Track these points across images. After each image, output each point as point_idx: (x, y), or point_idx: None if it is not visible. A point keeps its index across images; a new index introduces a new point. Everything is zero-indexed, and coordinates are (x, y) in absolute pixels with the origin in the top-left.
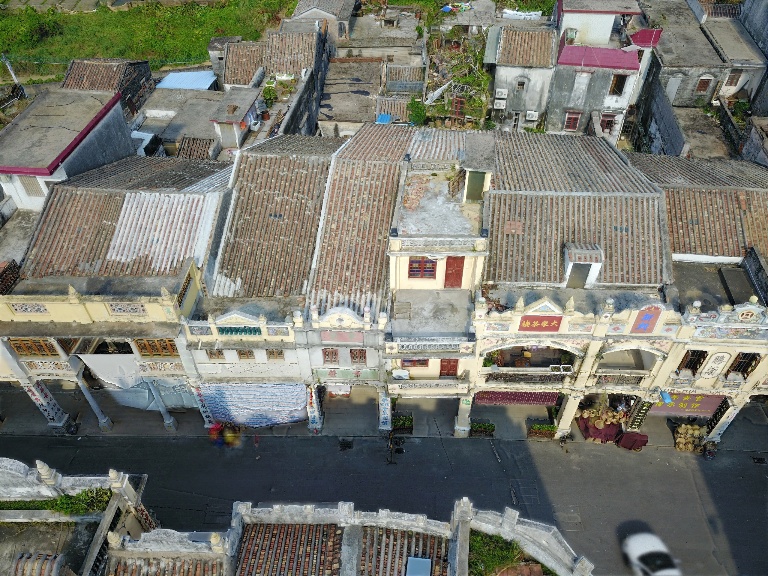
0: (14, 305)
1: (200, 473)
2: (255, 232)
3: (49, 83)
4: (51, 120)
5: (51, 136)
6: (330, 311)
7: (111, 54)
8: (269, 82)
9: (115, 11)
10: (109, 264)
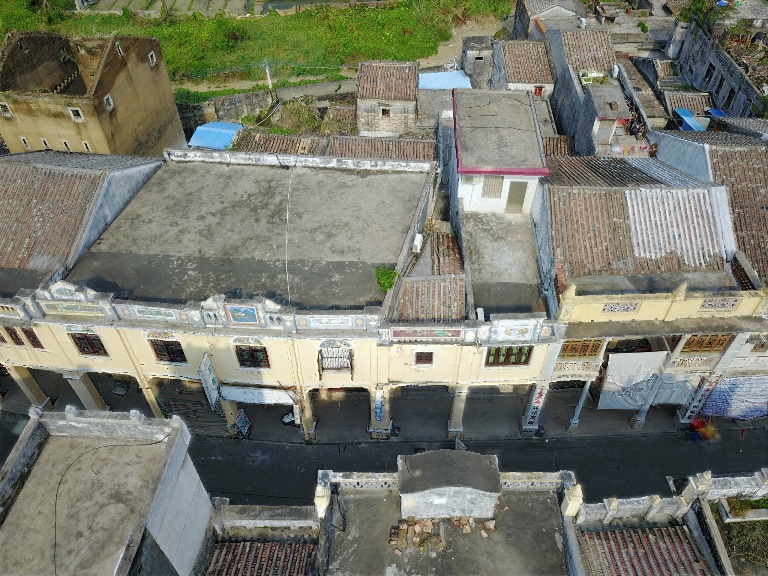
0: (606, 305)
1: (694, 469)
2: (753, 225)
3: (288, 88)
4: (489, 120)
5: (508, 136)
6: None
7: (316, 58)
8: (587, 79)
9: (282, 15)
10: (641, 261)
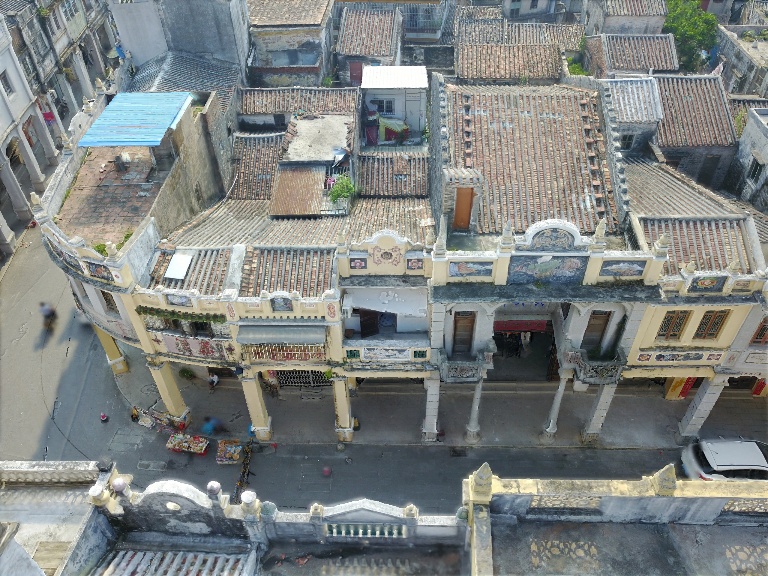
0: None
1: None
2: None
3: None
4: None
5: None
6: (186, 488)
7: None
8: None
9: None
10: None
